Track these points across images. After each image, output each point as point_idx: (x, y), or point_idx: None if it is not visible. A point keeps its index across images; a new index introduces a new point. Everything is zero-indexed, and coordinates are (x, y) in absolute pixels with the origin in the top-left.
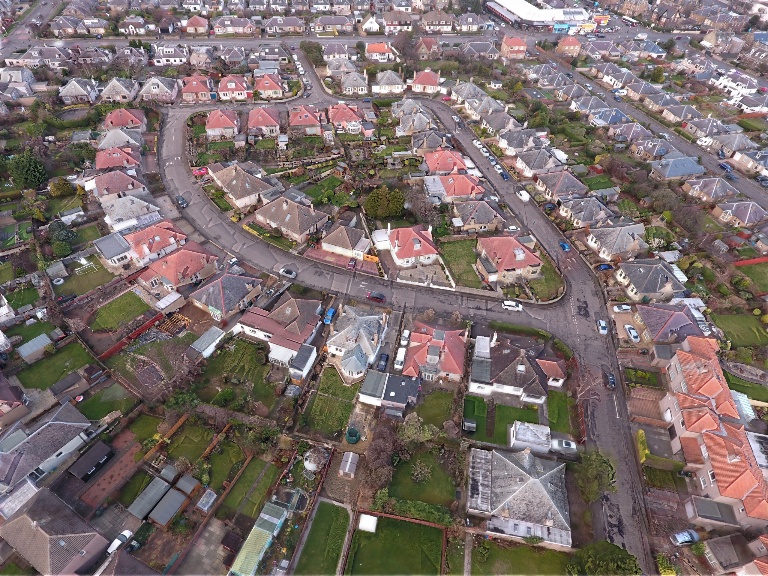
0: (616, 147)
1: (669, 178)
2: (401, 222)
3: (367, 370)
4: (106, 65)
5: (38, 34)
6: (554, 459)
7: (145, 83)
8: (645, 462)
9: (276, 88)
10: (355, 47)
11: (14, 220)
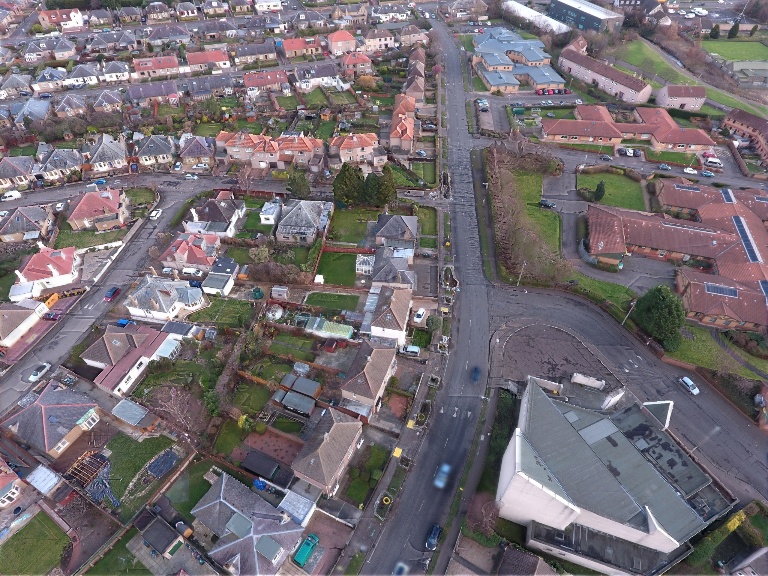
0: None
1: (45, 118)
2: None
3: None
4: None
5: None
6: (286, 204)
7: None
8: None
9: None
10: None
11: None
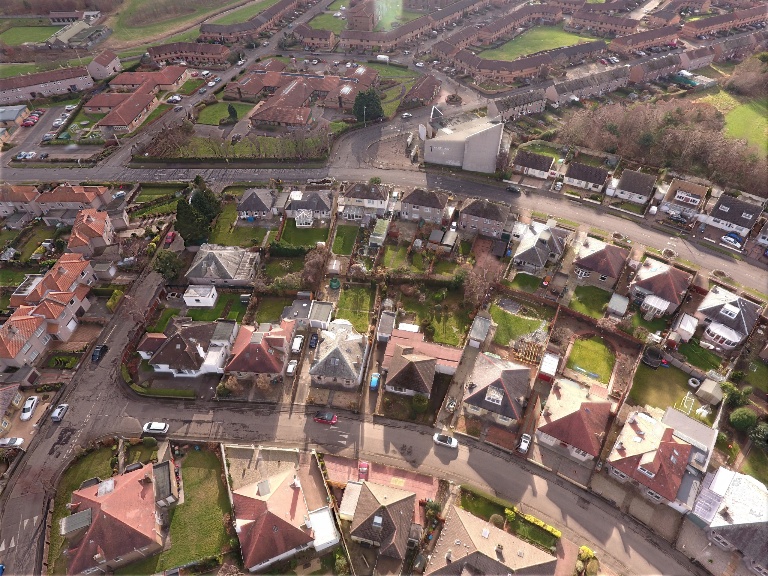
0: None
1: None
2: None
3: None
4: None
5: None
6: None
7: None
8: None
9: None
10: None
11: None
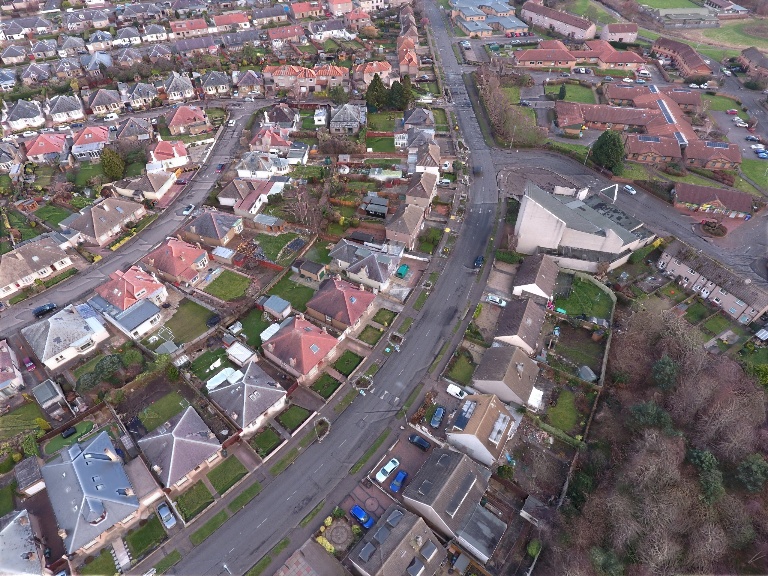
0: None
1: None
2: (129, 168)
3: None
4: None
5: None
6: None
7: None
8: None
9: None
10: None
11: None
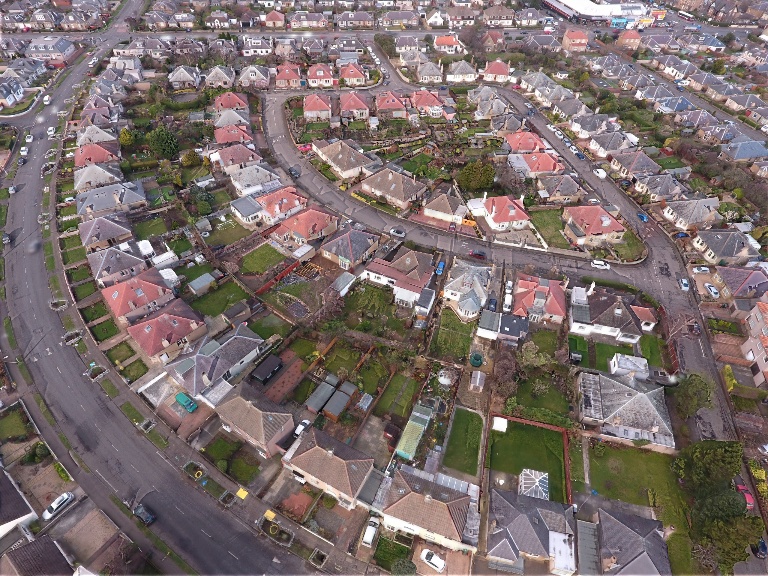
0: (684, 132)
1: (737, 160)
2: (490, 194)
3: (481, 310)
4: (202, 55)
5: (135, 27)
6: (653, 384)
7: (242, 71)
8: (732, 391)
9: (360, 76)
10: (423, 40)
11: (157, 184)
